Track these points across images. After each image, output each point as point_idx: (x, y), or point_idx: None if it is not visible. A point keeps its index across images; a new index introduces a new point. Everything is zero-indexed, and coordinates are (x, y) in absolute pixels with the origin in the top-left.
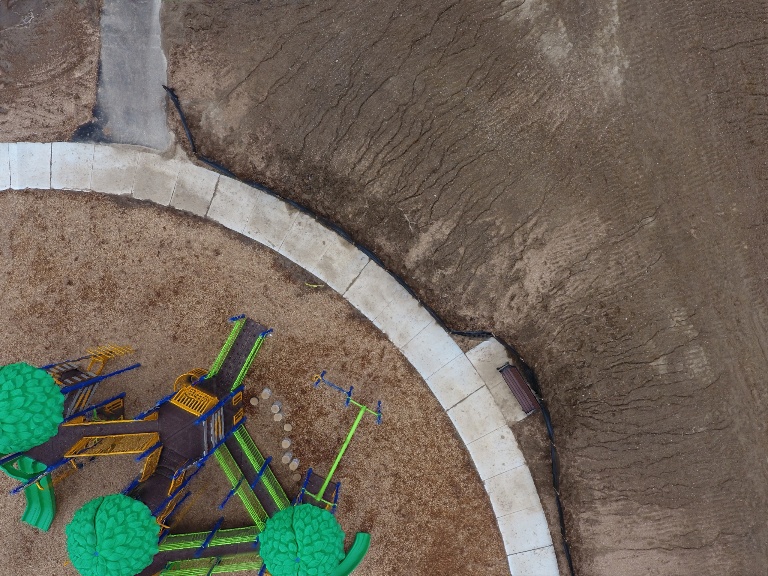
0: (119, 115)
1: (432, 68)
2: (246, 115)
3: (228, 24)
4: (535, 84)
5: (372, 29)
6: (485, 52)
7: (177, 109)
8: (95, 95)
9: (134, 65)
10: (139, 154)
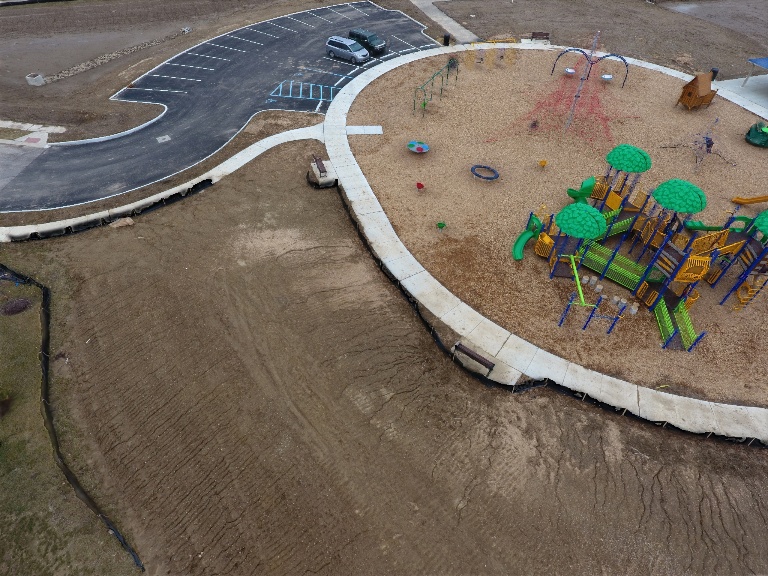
0: None
1: None
2: None
3: None
4: None
5: None
6: None
7: None
8: None
9: None
10: None
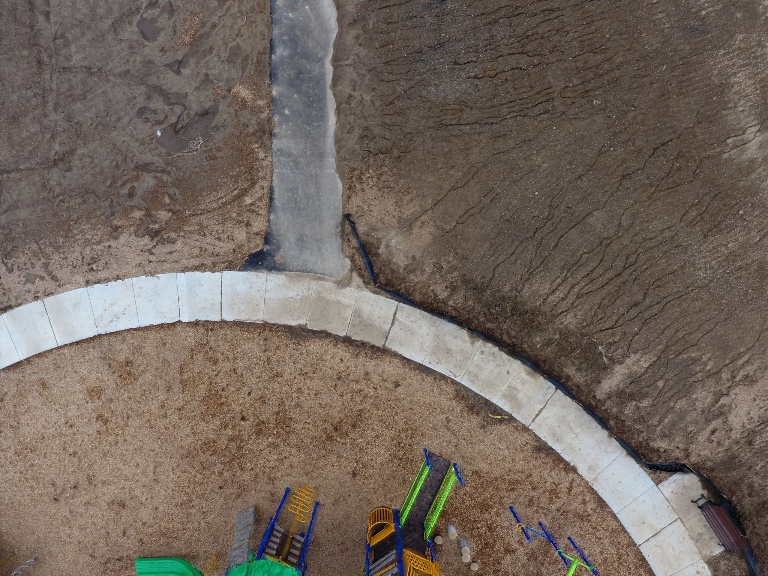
0: (292, 242)
1: (642, 202)
2: (431, 244)
3: (411, 149)
4: (759, 222)
5: (579, 162)
6: (704, 188)
7: (357, 238)
8: (267, 222)
9: (308, 190)
10: (313, 282)
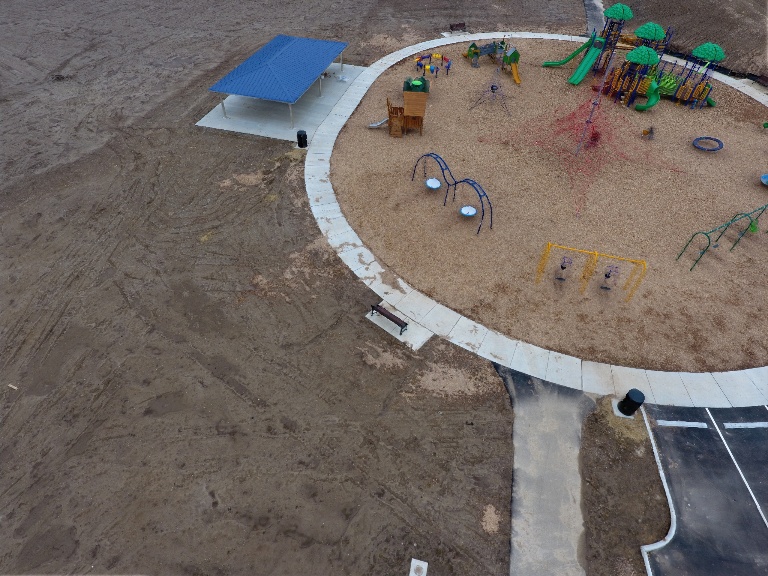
0: None
1: None
2: None
3: None
4: None
5: None
6: None
7: None
8: None
9: None
10: None
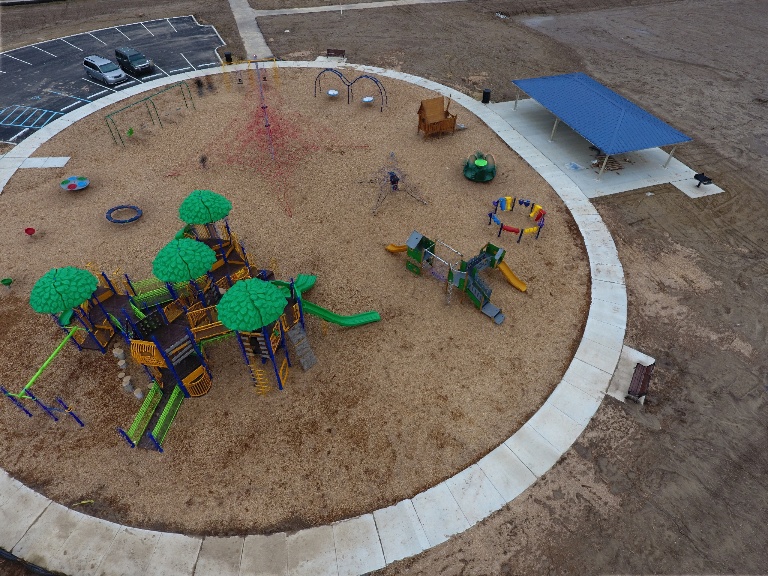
0: None
1: None
2: None
3: None
4: None
5: None
6: None
7: None
8: None
9: None
10: None
